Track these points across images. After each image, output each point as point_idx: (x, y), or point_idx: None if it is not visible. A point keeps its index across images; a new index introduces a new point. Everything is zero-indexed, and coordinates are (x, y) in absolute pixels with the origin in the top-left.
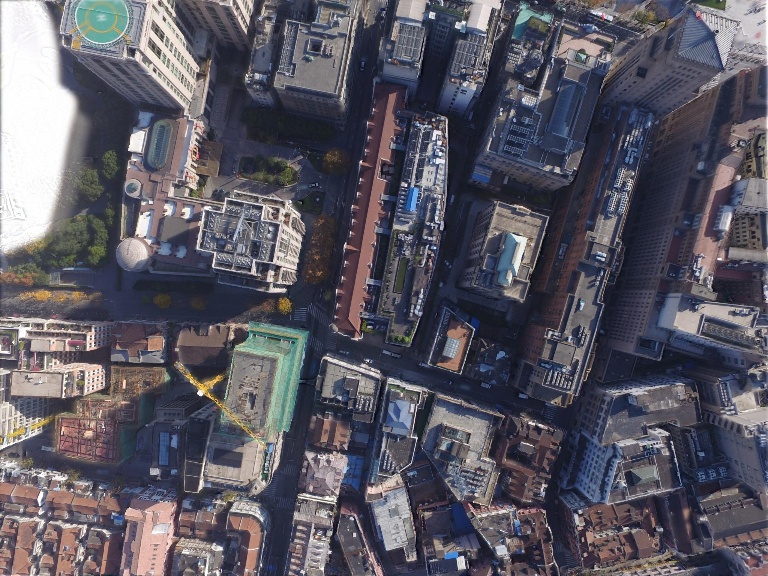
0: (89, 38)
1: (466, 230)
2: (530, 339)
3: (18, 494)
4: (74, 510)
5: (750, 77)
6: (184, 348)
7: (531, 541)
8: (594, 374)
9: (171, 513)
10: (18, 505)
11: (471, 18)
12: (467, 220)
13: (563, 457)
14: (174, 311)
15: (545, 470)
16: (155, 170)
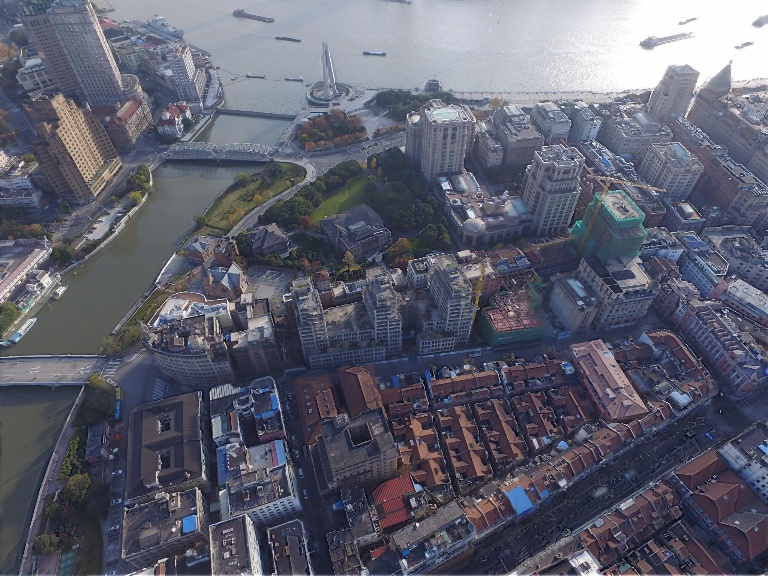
0: (444, 119)
1: None
2: (721, 198)
3: (480, 376)
4: (529, 376)
5: (706, 88)
6: (541, 248)
7: None
8: None
9: None
10: None
11: (579, 105)
12: None
13: None
14: None
15: None
16: (463, 193)
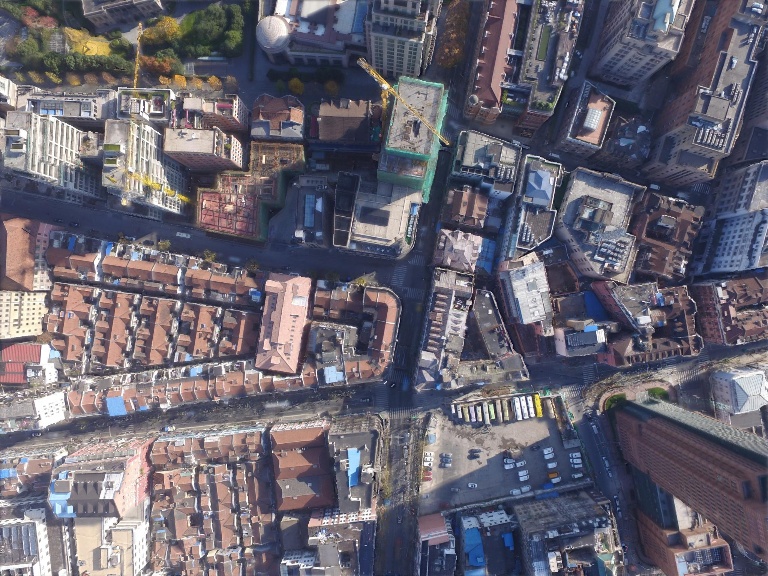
0: None
1: (597, 20)
2: (671, 113)
3: (158, 270)
4: (211, 288)
5: None
6: (325, 119)
7: (674, 312)
8: (730, 160)
9: (309, 287)
10: (157, 283)
11: None
12: (598, 10)
13: (694, 250)
14: (304, 102)
15: (686, 245)
16: None
